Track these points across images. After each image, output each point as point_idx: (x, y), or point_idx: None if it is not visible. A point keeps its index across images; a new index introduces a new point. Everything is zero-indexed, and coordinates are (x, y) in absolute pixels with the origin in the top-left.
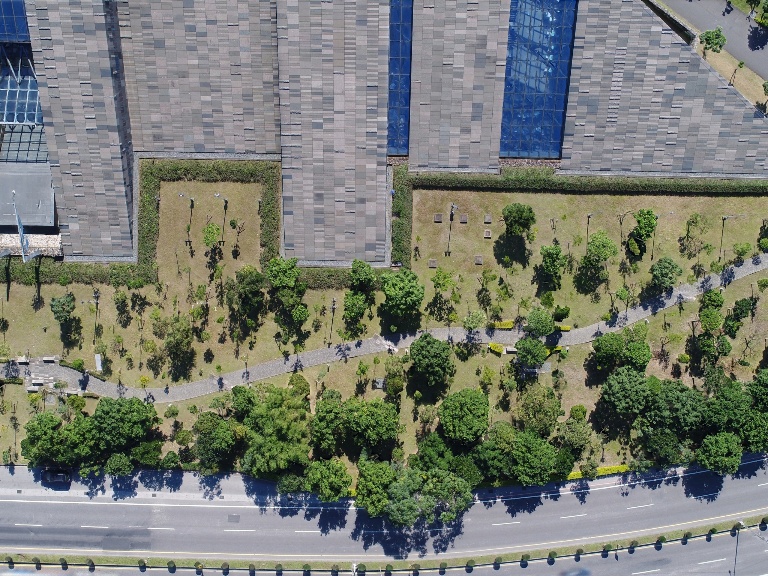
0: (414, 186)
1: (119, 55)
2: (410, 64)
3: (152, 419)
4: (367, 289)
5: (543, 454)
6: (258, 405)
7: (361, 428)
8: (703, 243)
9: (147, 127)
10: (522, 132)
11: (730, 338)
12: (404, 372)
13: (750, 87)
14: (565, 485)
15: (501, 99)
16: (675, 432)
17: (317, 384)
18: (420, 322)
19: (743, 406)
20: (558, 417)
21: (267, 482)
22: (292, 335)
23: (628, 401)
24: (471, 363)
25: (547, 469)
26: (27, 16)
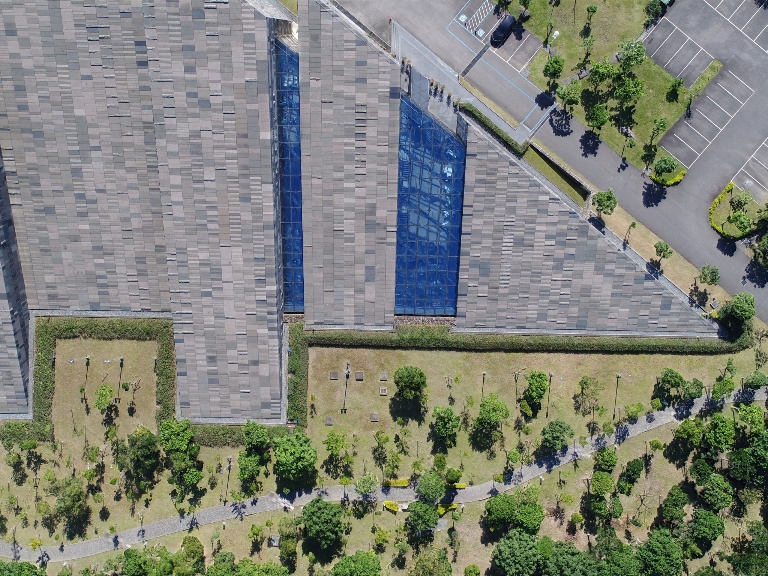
0: (310, 344)
1: (9, 222)
2: (301, 229)
3: None
4: None
5: None
6: (148, 571)
7: None
8: (597, 400)
9: (41, 287)
10: None
11: (625, 495)
12: (300, 530)
13: (644, 244)
14: None
15: (393, 262)
16: None
17: (213, 542)
18: (316, 480)
19: (632, 572)
20: (454, 575)
21: None
22: (188, 492)
23: (518, 567)
24: (367, 521)
25: None
26: None
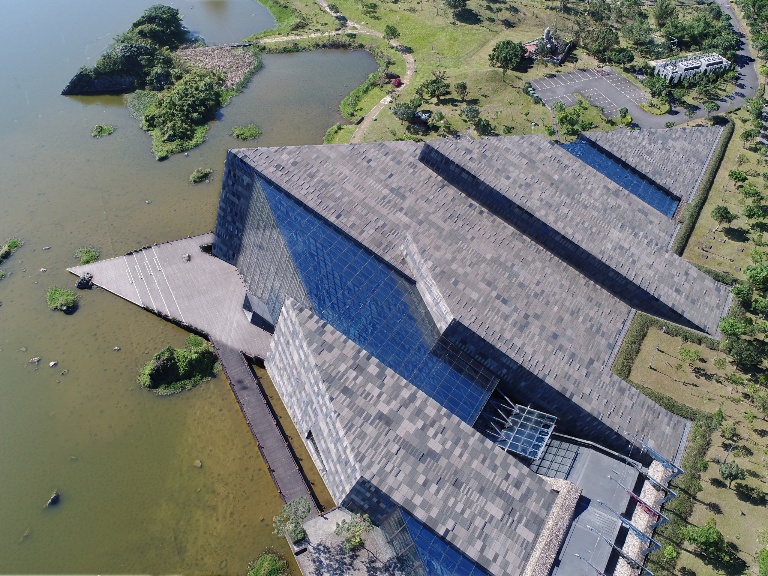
0: None
1: None
2: None
3: None
4: (750, 304)
5: None
6: None
7: None
8: (752, 169)
9: None
10: None
11: None
12: None
13: None
14: None
15: (640, 200)
16: None
17: None
18: None
19: None
20: None
21: None
22: None
23: None
24: None
25: None
26: (499, 349)
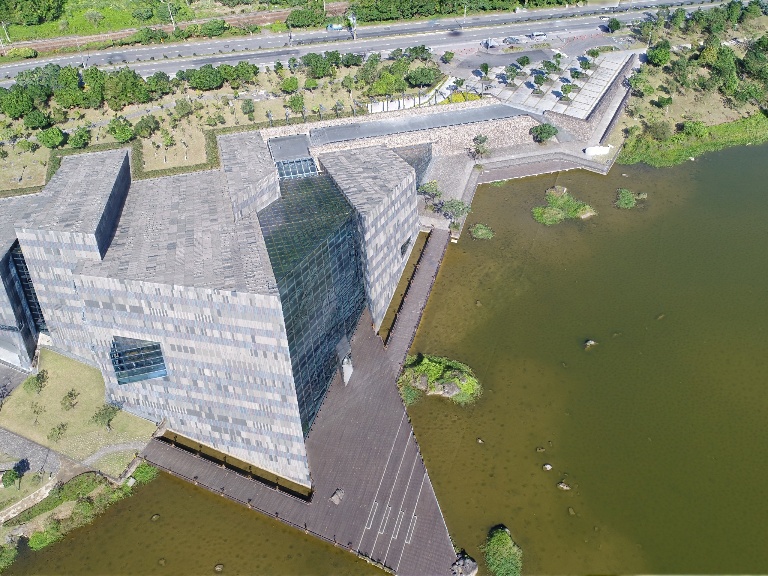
0: None
1: None
2: None
3: None
4: None
5: None
6: None
7: None
8: None
9: None
10: None
11: None
12: None
13: None
14: None
15: None
16: None
17: None
18: None
19: None
20: None
21: None
22: None
23: None
24: None
25: None
26: None
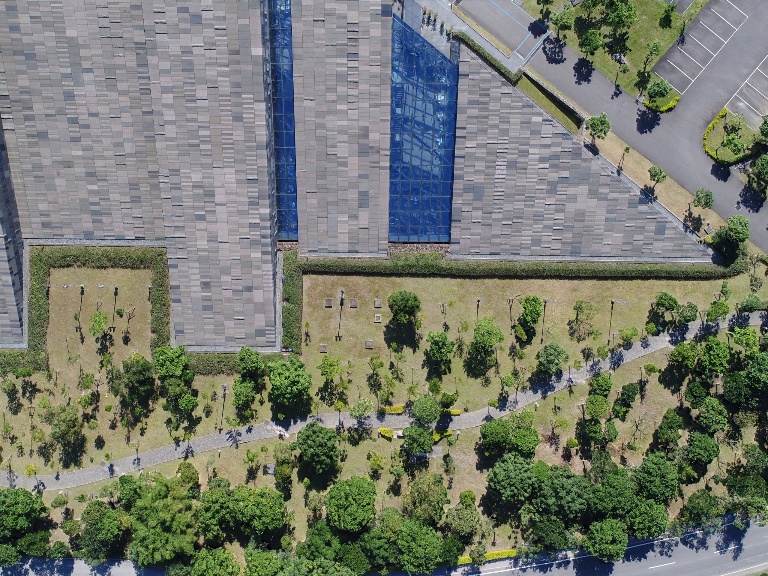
0: (304, 271)
1: (2, 147)
2: (295, 153)
3: (39, 509)
4: (258, 374)
5: (428, 543)
6: (144, 496)
7: (247, 518)
8: (592, 326)
9: (35, 215)
10: (414, 215)
11: (620, 421)
12: (295, 457)
13: (638, 170)
14: (456, 569)
15: (387, 187)
16: (561, 519)
17: (208, 470)
18: (311, 407)
19: (627, 494)
20: None
21: (158, 569)
22: (183, 421)
23: (513, 489)
24: (362, 448)
25: (432, 558)
26: None
